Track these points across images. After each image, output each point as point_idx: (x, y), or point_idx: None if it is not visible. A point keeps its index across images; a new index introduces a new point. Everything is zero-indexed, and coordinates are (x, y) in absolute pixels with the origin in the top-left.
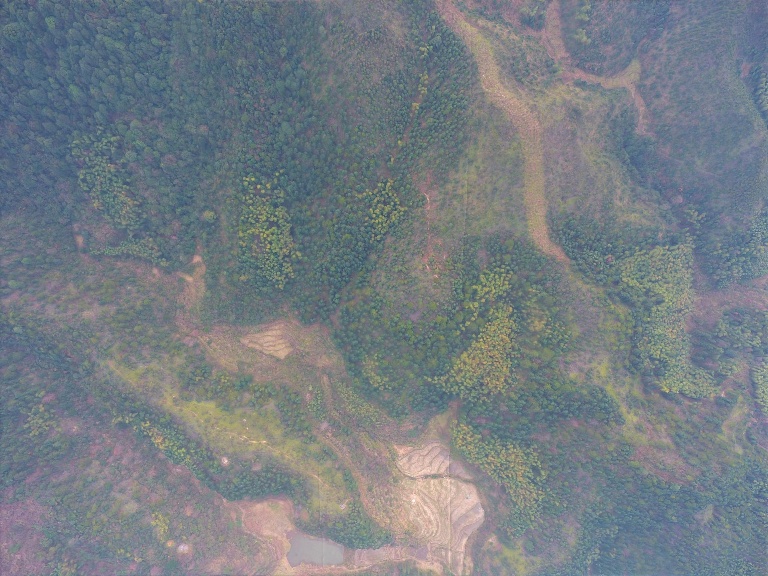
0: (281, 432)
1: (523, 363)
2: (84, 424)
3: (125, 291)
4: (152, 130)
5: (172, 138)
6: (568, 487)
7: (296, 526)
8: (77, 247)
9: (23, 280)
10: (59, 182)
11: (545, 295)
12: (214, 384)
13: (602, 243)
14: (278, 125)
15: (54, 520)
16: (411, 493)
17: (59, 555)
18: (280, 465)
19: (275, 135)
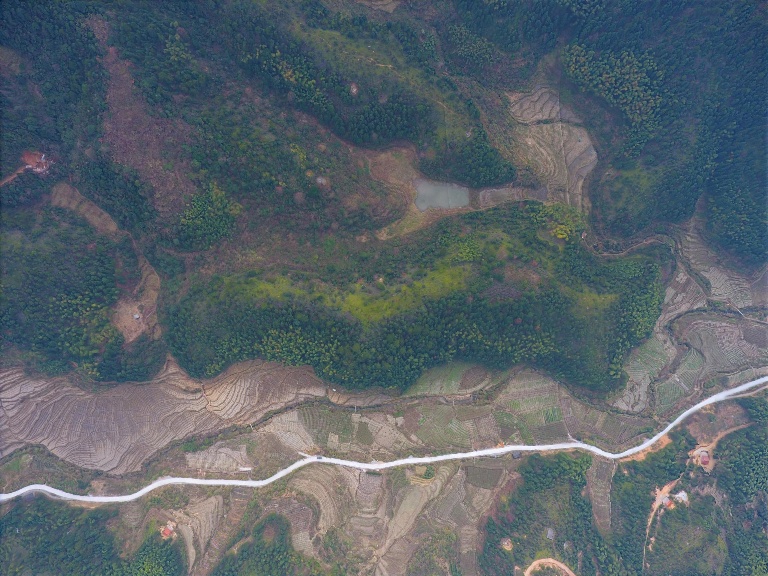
0: (404, 60)
1: None
2: (215, 64)
3: None
4: None
5: None
6: None
7: (422, 169)
8: None
9: None
10: None
11: None
12: None
13: None
14: None
15: (202, 138)
16: (526, 137)
17: None
18: (406, 92)
19: None
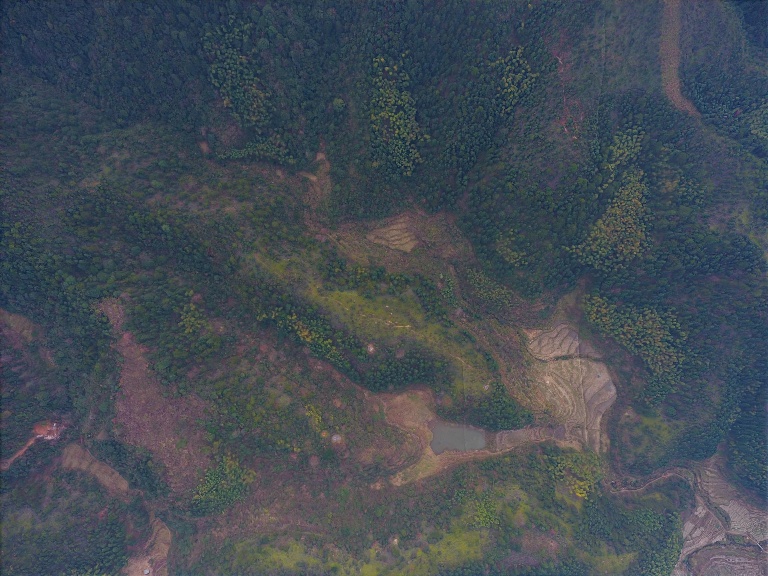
0: (422, 317)
1: (660, 223)
2: (230, 324)
3: (257, 190)
4: (282, 16)
5: (300, 25)
6: (710, 344)
7: (438, 414)
8: (202, 154)
9: (162, 181)
10: (187, 82)
11: (679, 152)
12: (352, 275)
13: (730, 96)
14: (404, 3)
15: (217, 413)
16: (544, 375)
17: (222, 450)
18: (424, 349)
19: (401, 13)
